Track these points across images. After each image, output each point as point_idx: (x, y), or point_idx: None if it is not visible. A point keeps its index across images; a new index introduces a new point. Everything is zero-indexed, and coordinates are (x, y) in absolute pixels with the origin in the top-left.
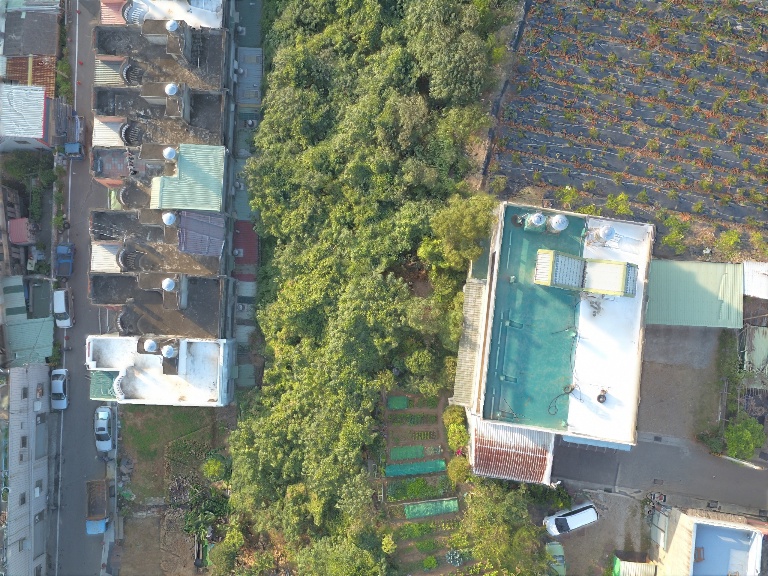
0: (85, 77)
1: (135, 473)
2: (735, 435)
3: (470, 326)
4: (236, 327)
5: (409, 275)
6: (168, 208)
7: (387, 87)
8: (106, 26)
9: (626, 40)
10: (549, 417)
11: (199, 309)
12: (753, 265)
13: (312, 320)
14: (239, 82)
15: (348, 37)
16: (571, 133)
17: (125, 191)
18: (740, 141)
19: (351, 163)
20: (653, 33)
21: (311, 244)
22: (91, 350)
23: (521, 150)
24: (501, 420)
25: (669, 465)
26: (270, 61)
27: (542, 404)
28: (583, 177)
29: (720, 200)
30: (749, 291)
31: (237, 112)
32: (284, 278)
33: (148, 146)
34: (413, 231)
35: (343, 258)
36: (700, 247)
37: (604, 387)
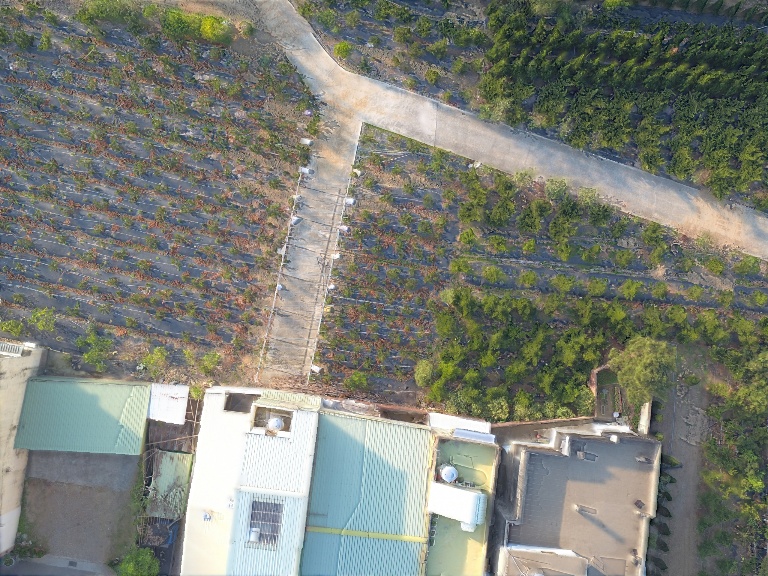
0: None
1: None
2: (123, 567)
3: None
4: None
5: None
6: None
7: None
8: None
9: (70, 145)
10: None
11: None
12: (161, 388)
13: None
14: None
15: None
16: (5, 242)
17: None
18: (182, 253)
19: None
20: (97, 139)
21: None
22: None
23: None
24: None
25: None
26: None
27: None
28: (14, 289)
29: (155, 315)
30: (154, 415)
31: None
32: None
33: None
34: None
35: None
36: (133, 363)
37: None
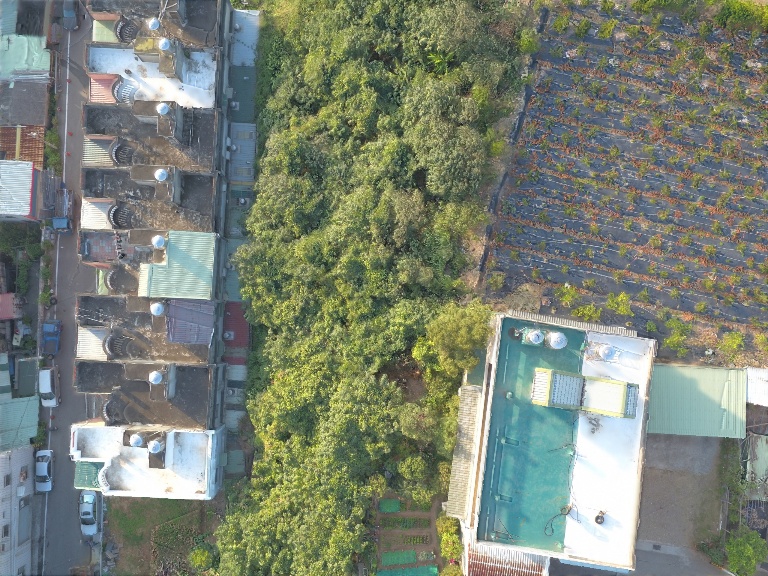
0: (74, 148)
1: (121, 558)
2: (736, 550)
3: (465, 435)
4: (226, 412)
5: (403, 373)
6: (156, 297)
7: (383, 178)
8: (95, 105)
9: (629, 132)
10: (545, 538)
11: (187, 397)
12: (757, 372)
13: (303, 417)
14: (232, 159)
15: (343, 121)
16: (571, 229)
17: (113, 274)
18: (744, 238)
19: (345, 258)
20: (656, 126)
21: (303, 337)
22: (76, 439)
23: (520, 245)
24: (495, 541)
25: (668, 575)
26: (264, 140)
27: (538, 524)
28: (583, 274)
29: (723, 300)
30: (752, 399)
31: (229, 190)
32: (275, 370)
33: (137, 232)
34: (407, 330)
35: (335, 354)
36: (702, 348)
37: (602, 508)
